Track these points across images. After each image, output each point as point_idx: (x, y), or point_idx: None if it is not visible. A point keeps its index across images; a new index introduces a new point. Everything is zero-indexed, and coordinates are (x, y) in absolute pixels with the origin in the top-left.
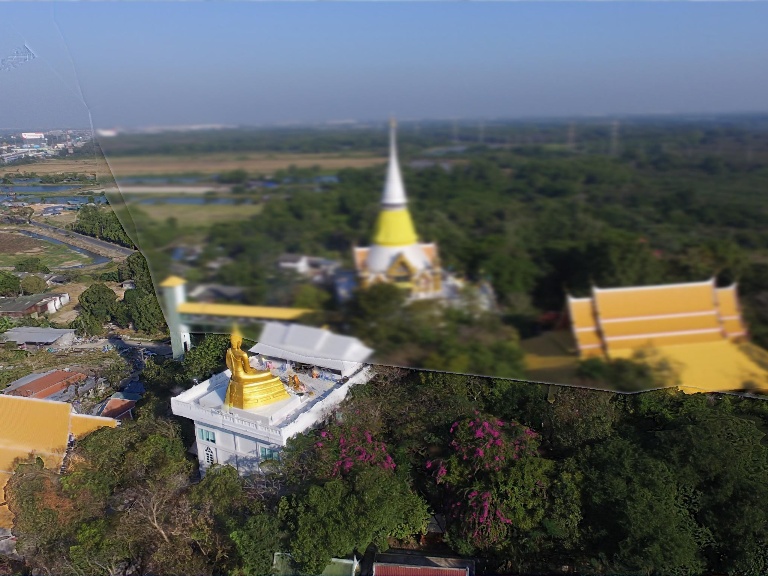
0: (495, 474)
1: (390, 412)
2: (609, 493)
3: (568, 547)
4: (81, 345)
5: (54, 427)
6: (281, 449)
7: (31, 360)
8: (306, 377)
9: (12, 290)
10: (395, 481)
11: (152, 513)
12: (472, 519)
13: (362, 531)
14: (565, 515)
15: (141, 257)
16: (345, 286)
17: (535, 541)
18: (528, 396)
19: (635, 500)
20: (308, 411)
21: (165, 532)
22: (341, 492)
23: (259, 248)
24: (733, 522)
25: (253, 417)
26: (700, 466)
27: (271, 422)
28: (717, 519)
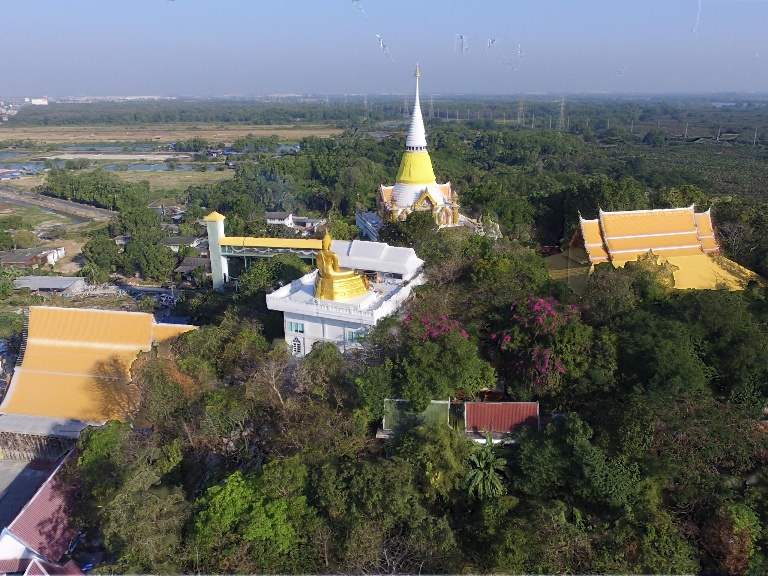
0: (553, 335)
1: (454, 301)
2: (640, 345)
3: (607, 390)
4: (93, 291)
5: (137, 335)
6: (368, 331)
7: (48, 304)
8: (370, 283)
9: (5, 244)
10: (473, 344)
11: (272, 379)
12: (533, 373)
13: (459, 374)
14: (605, 366)
15: (133, 213)
16: (760, 19)
17: (583, 386)
18: (561, 289)
19: (661, 347)
20: (389, 300)
21: (281, 395)
22: (437, 349)
23: (736, 4)
24: (732, 359)
25: (343, 306)
26: (707, 322)
27: (359, 309)
28: (719, 359)
